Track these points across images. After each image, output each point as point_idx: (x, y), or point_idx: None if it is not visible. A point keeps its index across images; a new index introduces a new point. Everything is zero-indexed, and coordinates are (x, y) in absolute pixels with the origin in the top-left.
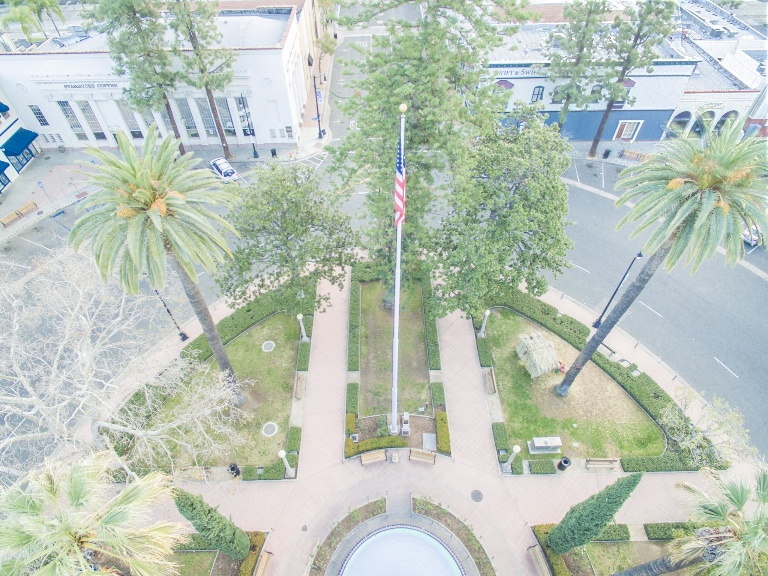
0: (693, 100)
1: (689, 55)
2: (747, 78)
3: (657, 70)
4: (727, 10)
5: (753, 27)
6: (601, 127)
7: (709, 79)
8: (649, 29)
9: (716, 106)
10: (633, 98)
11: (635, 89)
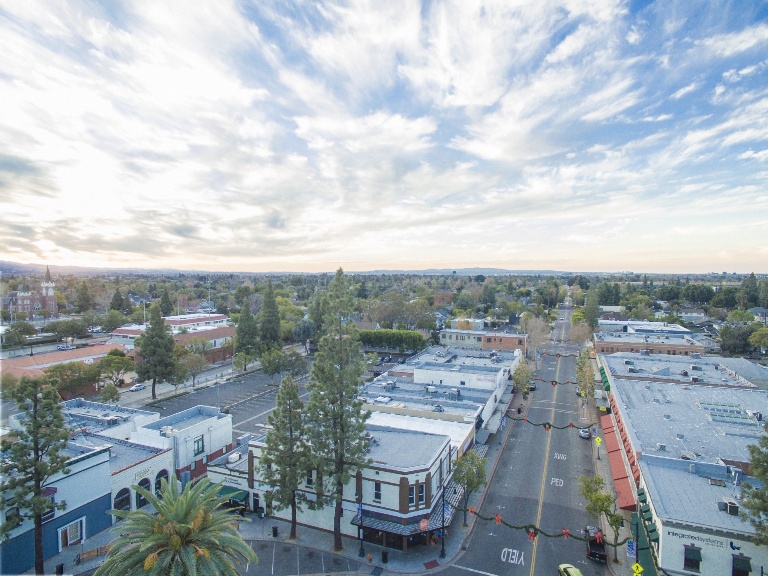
0: (123, 478)
1: (98, 446)
2: (157, 444)
3: (74, 469)
4: (111, 404)
5: (139, 409)
6: (38, 547)
7: (127, 456)
8: (46, 440)
9: (146, 473)
10: (62, 502)
11: (59, 494)
